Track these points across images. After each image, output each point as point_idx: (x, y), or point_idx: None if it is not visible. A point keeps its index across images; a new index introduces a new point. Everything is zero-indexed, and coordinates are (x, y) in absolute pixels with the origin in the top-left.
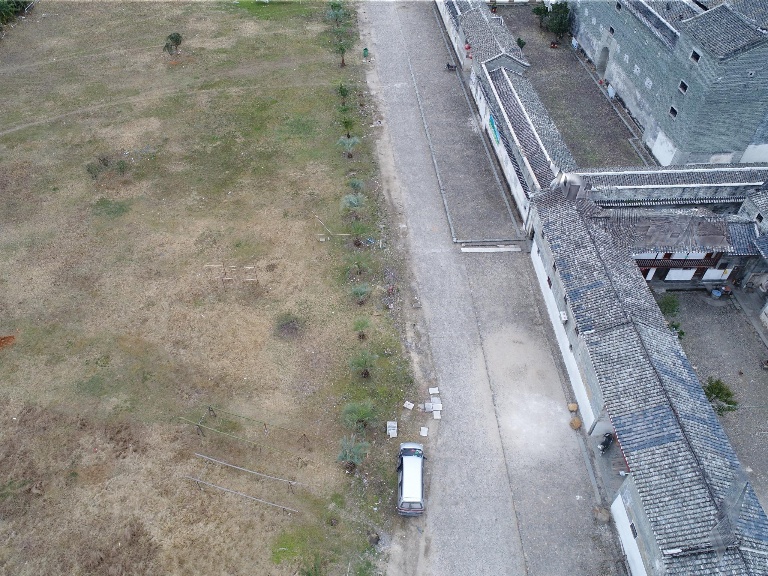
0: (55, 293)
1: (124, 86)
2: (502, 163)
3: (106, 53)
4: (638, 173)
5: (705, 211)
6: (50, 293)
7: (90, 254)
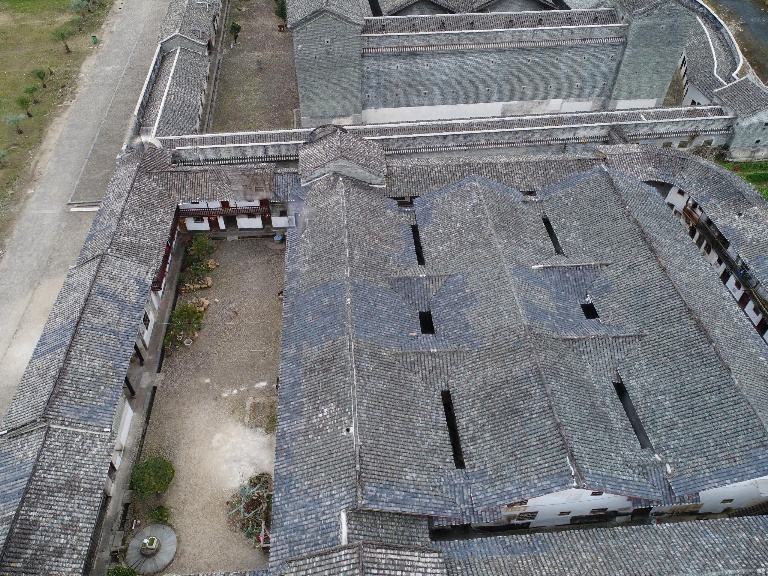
0: None
1: None
2: (150, 133)
3: None
4: (232, 135)
5: (270, 165)
6: None
7: None
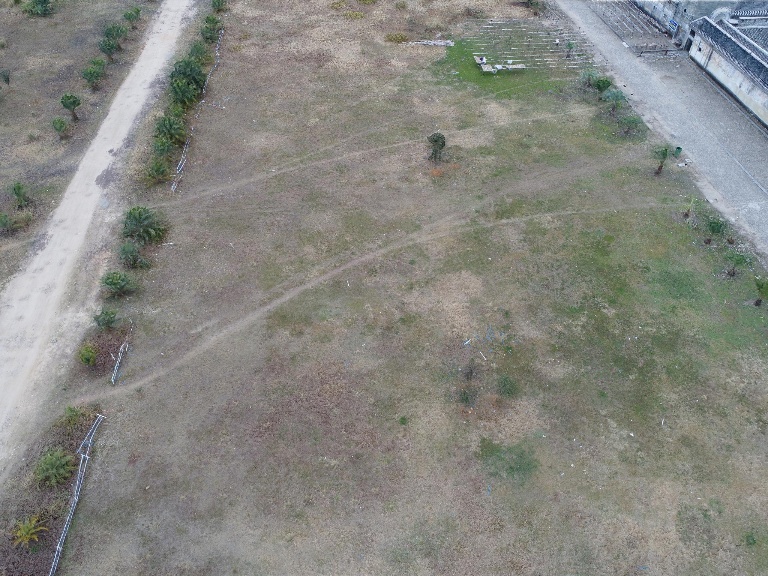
0: None
1: (393, 215)
2: None
3: (338, 157)
4: None
5: None
6: None
7: (533, 571)
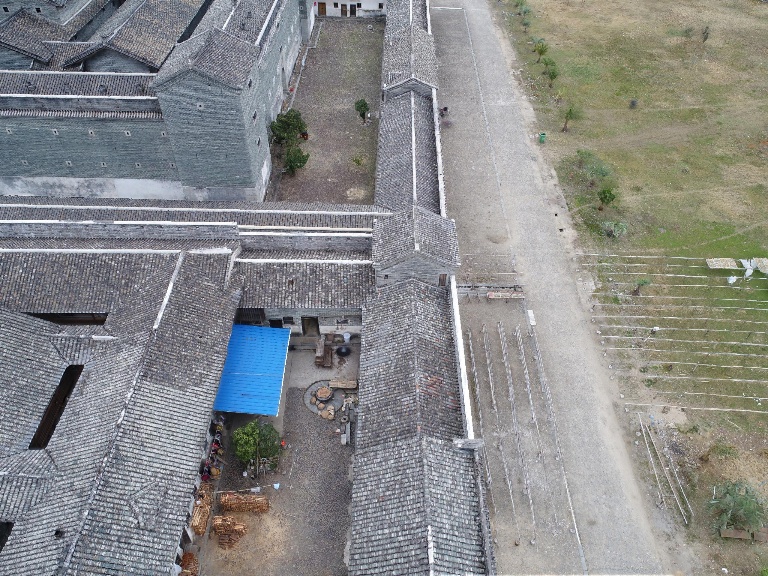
0: (666, 8)
1: None
2: None
3: None
4: None
5: None
6: (669, 8)
7: None
